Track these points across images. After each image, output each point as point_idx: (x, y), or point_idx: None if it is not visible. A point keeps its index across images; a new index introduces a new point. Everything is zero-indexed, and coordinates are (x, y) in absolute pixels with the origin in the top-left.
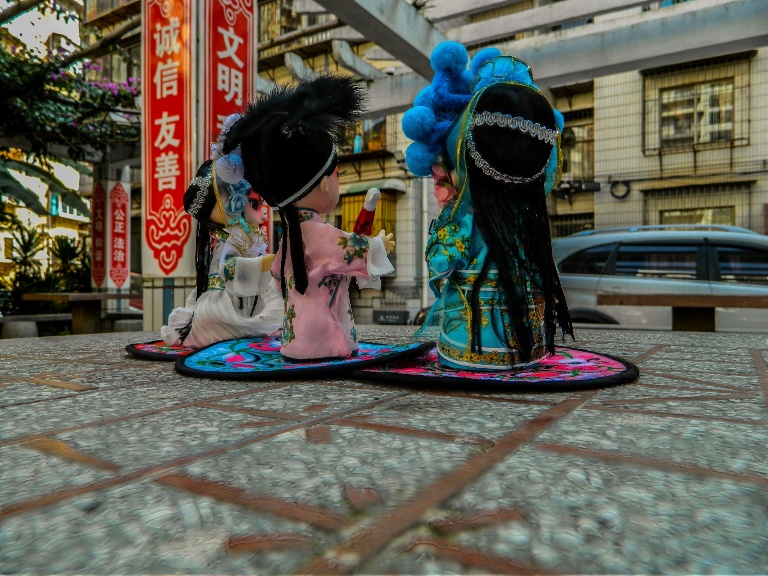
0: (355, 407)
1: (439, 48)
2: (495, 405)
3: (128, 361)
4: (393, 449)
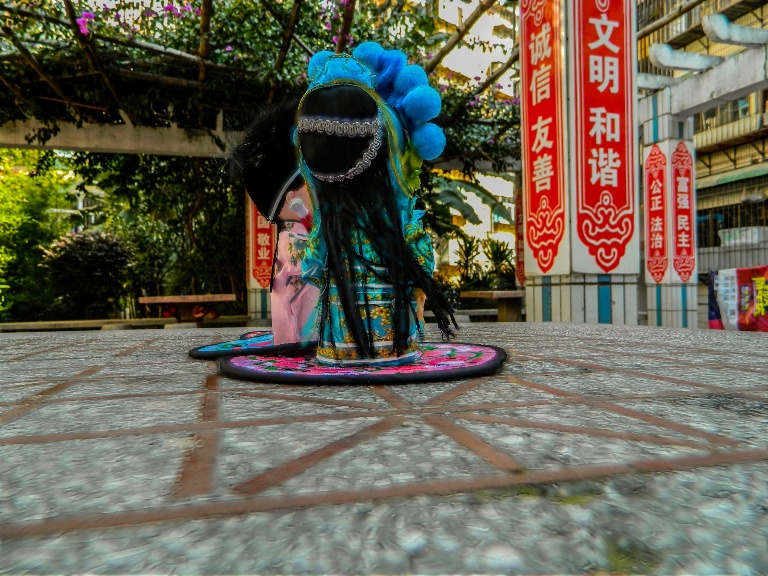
0: None
1: None
2: None
3: None
4: (6, 394)
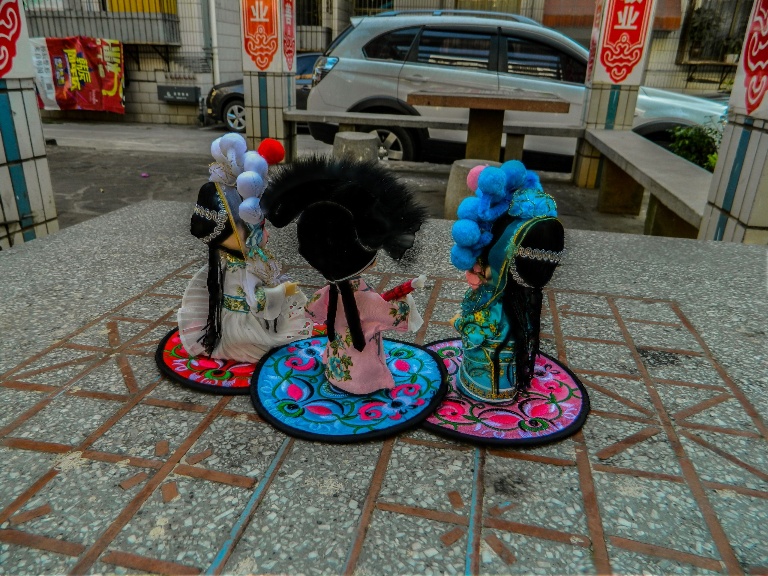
0: (476, 492)
1: (489, 178)
2: (547, 472)
3: (191, 397)
4: (551, 560)
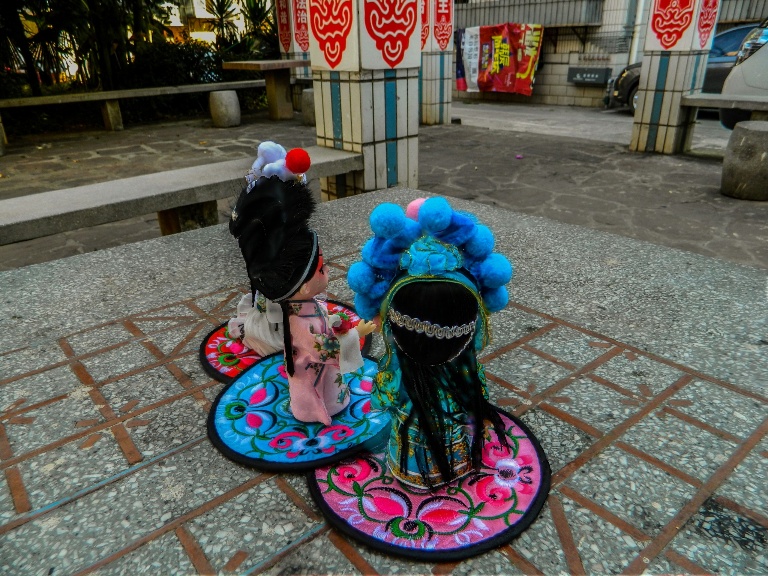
0: (261, 565)
1: (374, 218)
2: None
3: (195, 372)
4: None
